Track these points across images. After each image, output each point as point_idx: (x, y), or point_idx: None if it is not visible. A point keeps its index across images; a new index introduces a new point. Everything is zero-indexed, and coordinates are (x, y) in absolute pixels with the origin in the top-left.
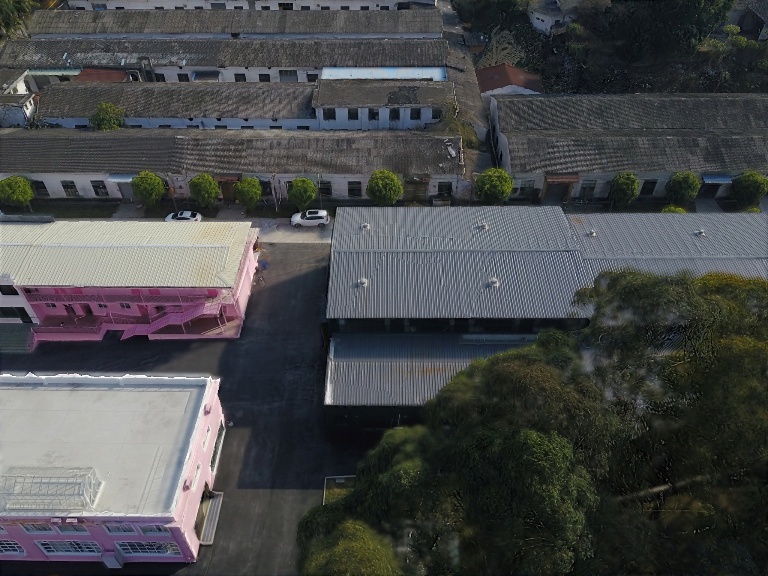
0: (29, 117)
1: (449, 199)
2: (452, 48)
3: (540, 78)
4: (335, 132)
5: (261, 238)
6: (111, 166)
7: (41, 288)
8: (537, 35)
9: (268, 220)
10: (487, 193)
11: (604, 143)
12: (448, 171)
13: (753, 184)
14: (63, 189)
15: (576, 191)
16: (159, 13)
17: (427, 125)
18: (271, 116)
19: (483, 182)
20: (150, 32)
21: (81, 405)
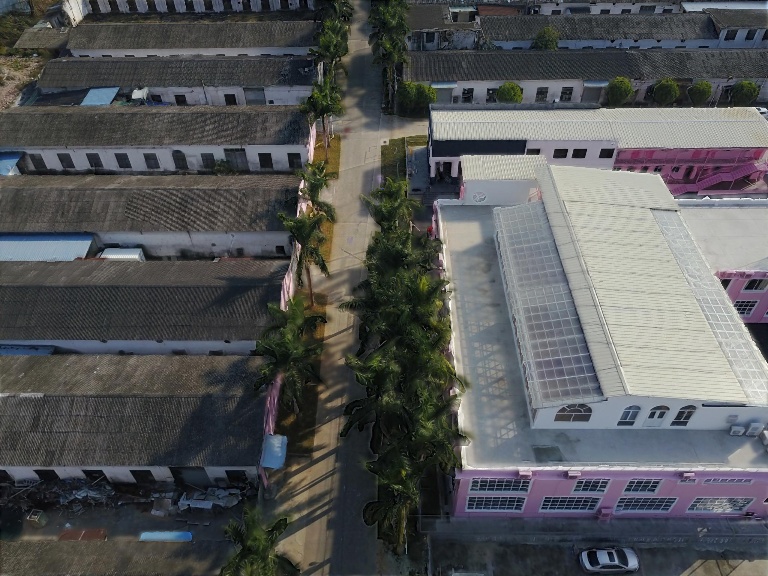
0: (477, 41)
1: None
2: None
3: None
4: None
5: None
6: (584, 74)
7: (623, 154)
8: None
9: None
10: None
11: None
12: None
13: None
14: (535, 95)
15: None
16: None
17: None
18: (682, 37)
19: None
20: None
21: (758, 216)
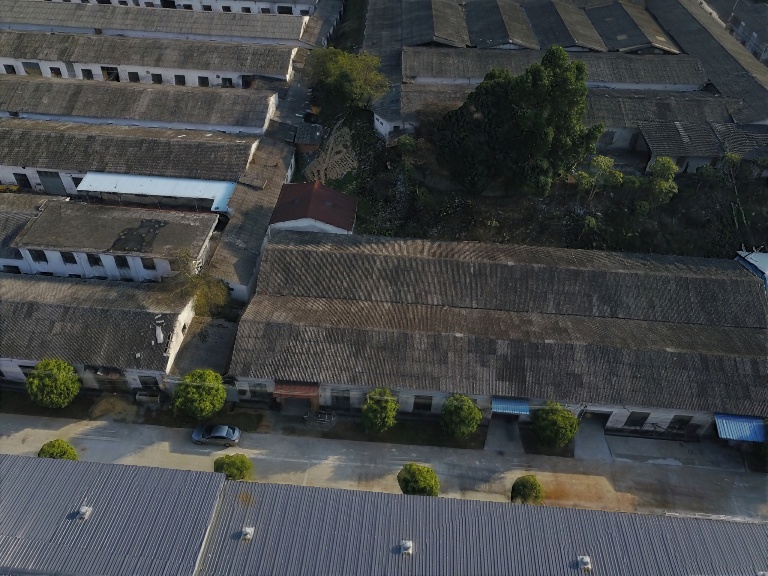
0: None
1: (158, 394)
2: (267, 150)
3: (366, 199)
4: (35, 284)
5: None
6: None
7: None
8: (374, 141)
9: None
10: (181, 408)
11: (367, 338)
12: (144, 366)
13: (550, 426)
14: None
15: (326, 399)
16: None
17: (162, 279)
18: None
19: (177, 393)
20: None
21: None
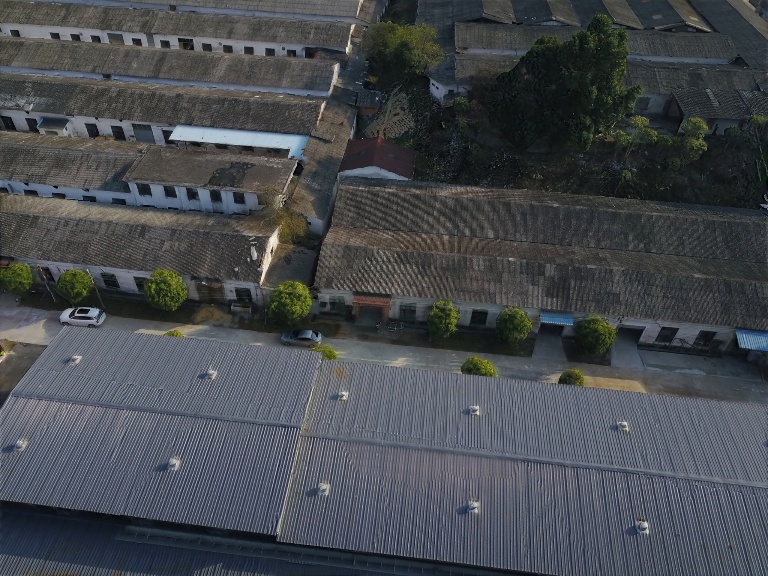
0: None
1: (250, 306)
2: (333, 111)
3: (423, 155)
4: (143, 212)
5: (19, 336)
6: None
7: None
8: (430, 103)
9: (40, 312)
10: (275, 311)
11: (432, 259)
12: (242, 277)
13: (592, 333)
14: None
15: (395, 312)
16: (33, 45)
17: (251, 212)
18: (81, 186)
19: (272, 298)
20: (17, 66)
21: None
